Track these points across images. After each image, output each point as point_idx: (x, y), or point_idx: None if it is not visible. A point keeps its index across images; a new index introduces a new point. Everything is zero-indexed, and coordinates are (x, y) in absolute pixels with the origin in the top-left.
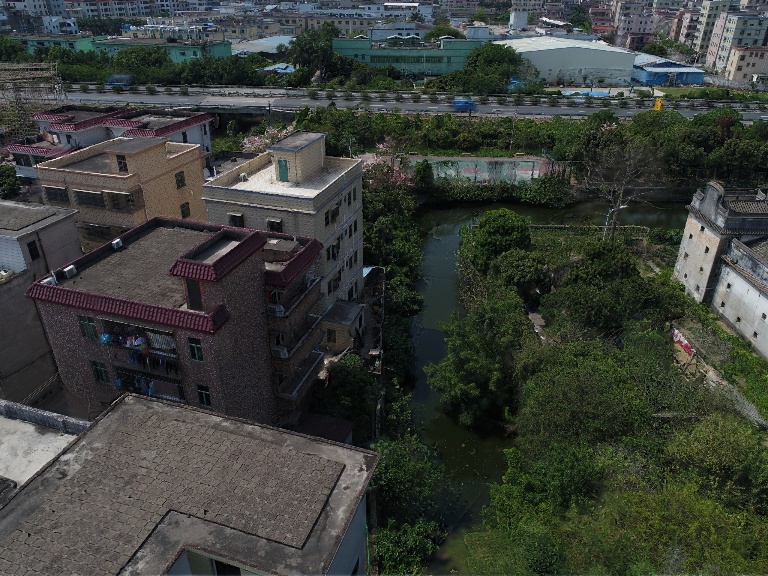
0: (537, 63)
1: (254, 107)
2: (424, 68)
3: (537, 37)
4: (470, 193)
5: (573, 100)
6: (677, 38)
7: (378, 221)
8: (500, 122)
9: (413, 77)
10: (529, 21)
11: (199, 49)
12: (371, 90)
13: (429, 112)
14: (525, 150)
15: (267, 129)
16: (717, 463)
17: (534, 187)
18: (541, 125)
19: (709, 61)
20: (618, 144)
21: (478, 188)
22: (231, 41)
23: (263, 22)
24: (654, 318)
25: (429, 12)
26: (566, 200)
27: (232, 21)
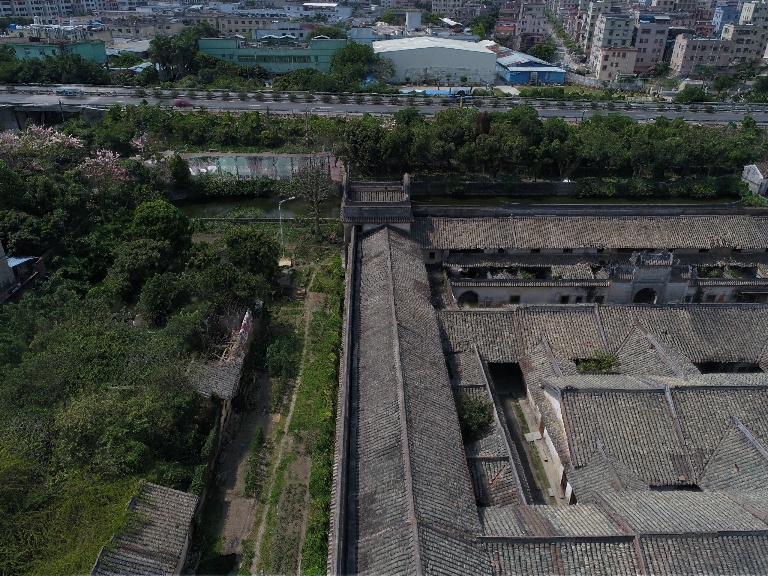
0: (402, 62)
1: (69, 105)
2: (292, 67)
3: (417, 37)
4: (227, 188)
5: (395, 98)
6: (578, 39)
7: (54, 214)
8: (309, 120)
9: (264, 76)
10: (426, 21)
11: (57, 48)
12: (211, 89)
13: (244, 110)
14: (327, 147)
15: (30, 126)
16: (73, 427)
17: (291, 182)
18: (350, 122)
19: (591, 61)
20: (374, 140)
21: (239, 183)
22: (119, 40)
23: (164, 22)
24: (219, 301)
25: (347, 12)
26: (321, 194)
27: (134, 21)
